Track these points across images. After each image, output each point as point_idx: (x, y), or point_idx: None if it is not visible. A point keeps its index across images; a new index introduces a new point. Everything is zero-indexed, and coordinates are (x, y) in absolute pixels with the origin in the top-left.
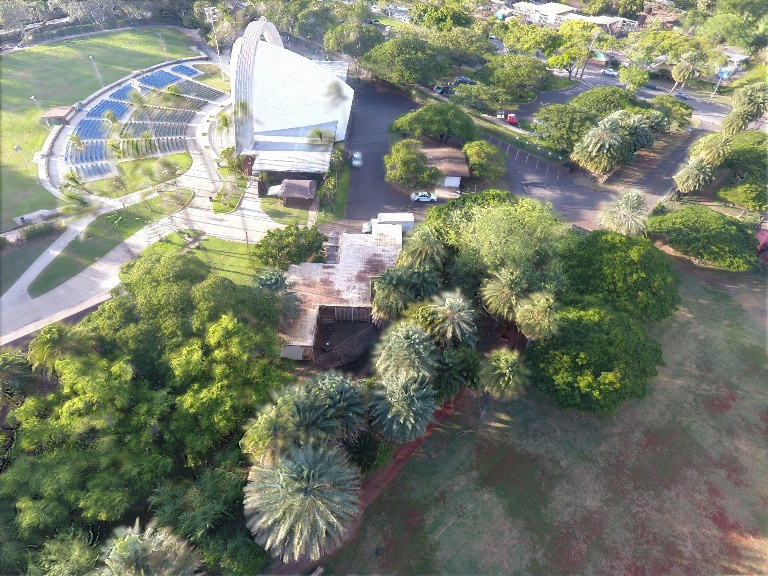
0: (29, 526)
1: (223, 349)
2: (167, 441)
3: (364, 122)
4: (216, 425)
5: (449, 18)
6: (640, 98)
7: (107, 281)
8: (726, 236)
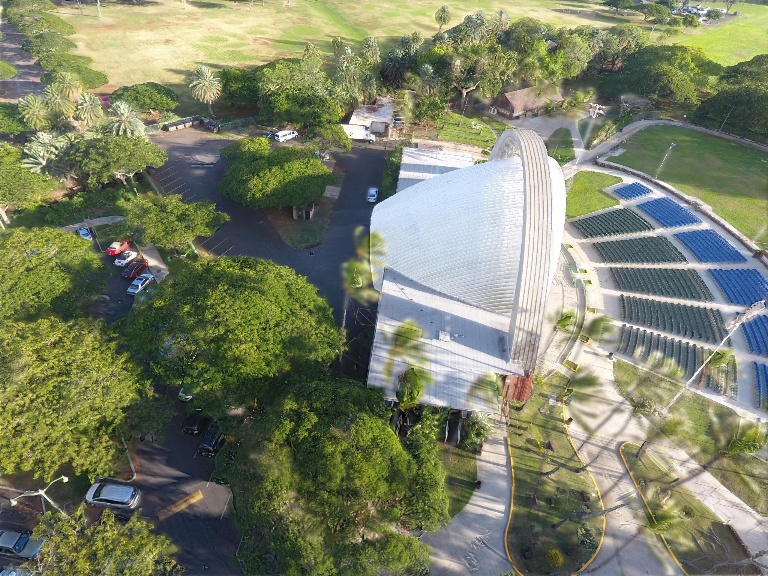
0: None
1: None
2: None
3: (353, 262)
4: None
5: None
6: None
7: None
8: (150, 82)
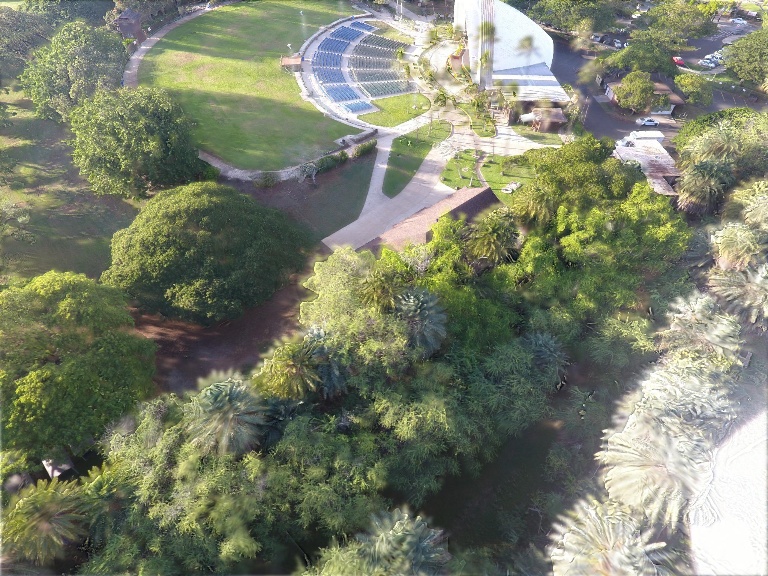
0: (585, 311)
1: (651, 204)
2: (628, 268)
3: None
4: (675, 251)
5: None
6: None
7: (437, 186)
8: None
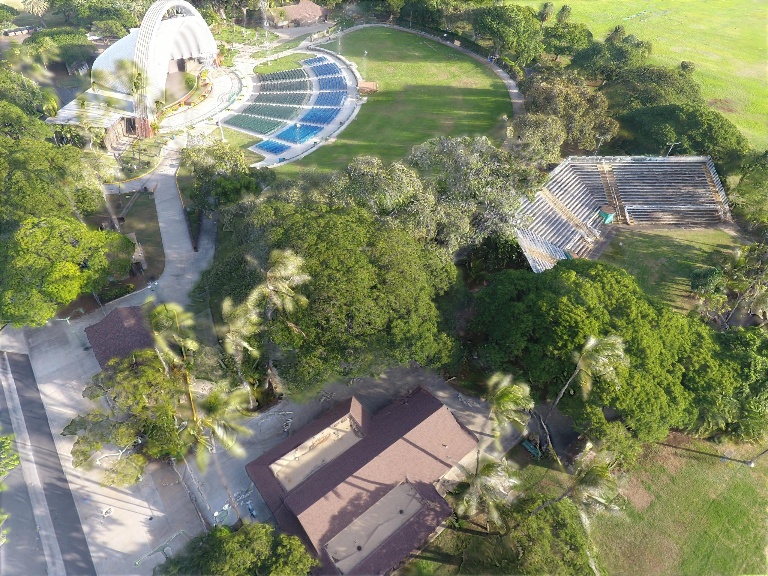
0: None
1: None
2: None
3: None
4: None
5: None
6: None
7: (284, 35)
8: None
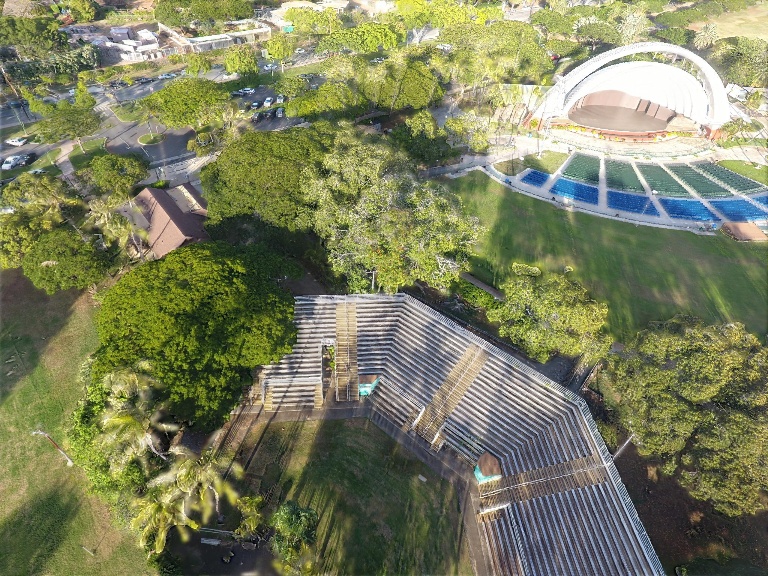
0: None
1: None
2: None
3: None
4: None
5: (389, 30)
6: None
7: None
8: None
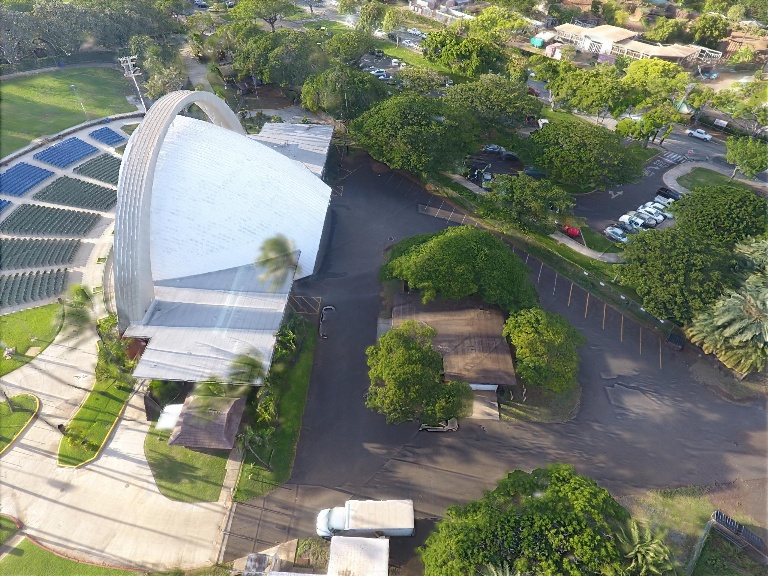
0: None
1: None
2: None
3: (348, 232)
4: None
5: (475, 55)
6: (755, 183)
7: None
8: None
